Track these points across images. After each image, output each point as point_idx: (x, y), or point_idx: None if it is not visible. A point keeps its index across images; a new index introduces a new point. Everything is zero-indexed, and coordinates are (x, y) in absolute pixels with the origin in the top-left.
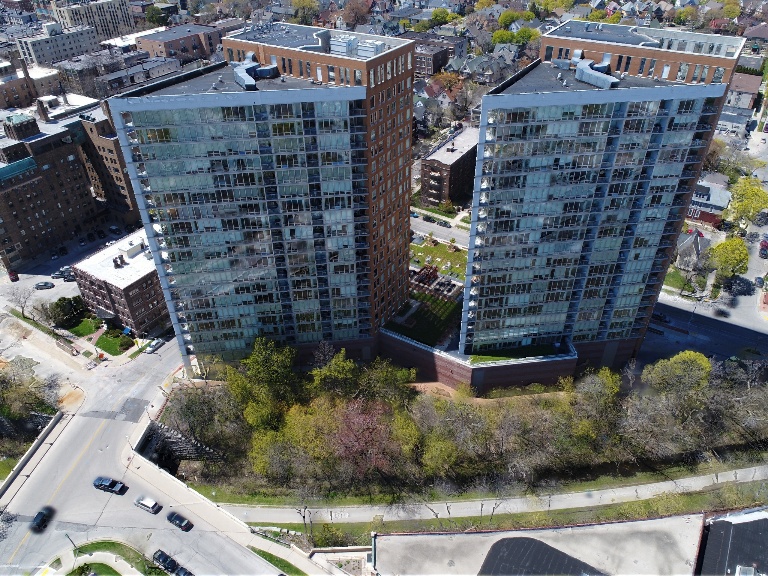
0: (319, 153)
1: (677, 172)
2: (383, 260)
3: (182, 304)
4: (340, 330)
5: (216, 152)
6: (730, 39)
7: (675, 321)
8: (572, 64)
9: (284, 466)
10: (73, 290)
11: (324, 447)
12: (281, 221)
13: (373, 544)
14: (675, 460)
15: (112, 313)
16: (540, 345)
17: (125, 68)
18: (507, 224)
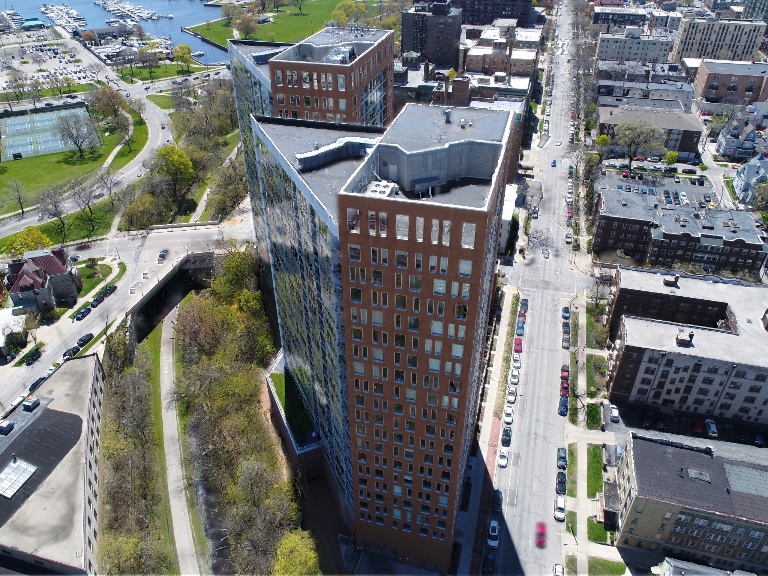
0: None
1: None
2: None
3: None
4: None
5: None
6: None
7: None
8: None
9: None
10: None
11: (180, 319)
12: None
13: None
14: None
15: None
16: None
17: (636, 81)
18: None
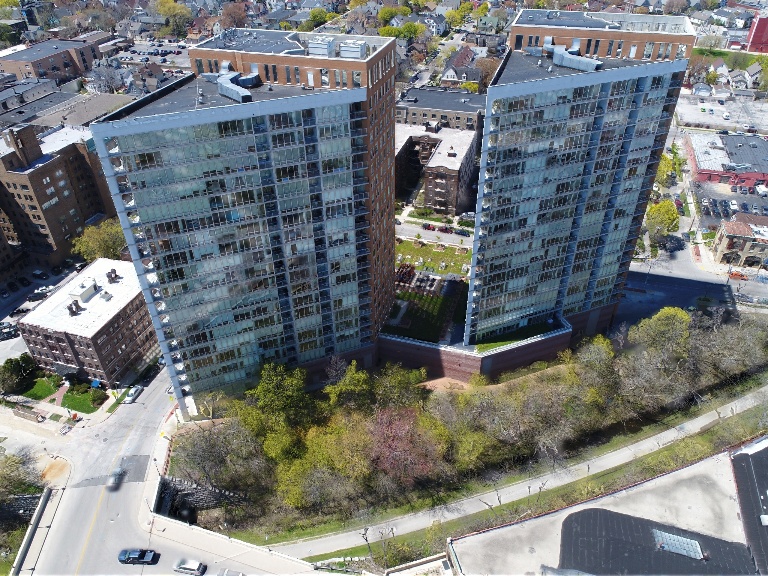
0: (320, 161)
1: (649, 144)
2: (379, 264)
3: (176, 343)
4: (342, 342)
5: (212, 172)
6: (674, 18)
7: (631, 283)
8: (544, 51)
9: (314, 493)
10: (12, 349)
11: (364, 464)
12: (282, 237)
13: (452, 550)
14: (671, 409)
15: (75, 367)
16: (535, 324)
17: None
18: (508, 211)
